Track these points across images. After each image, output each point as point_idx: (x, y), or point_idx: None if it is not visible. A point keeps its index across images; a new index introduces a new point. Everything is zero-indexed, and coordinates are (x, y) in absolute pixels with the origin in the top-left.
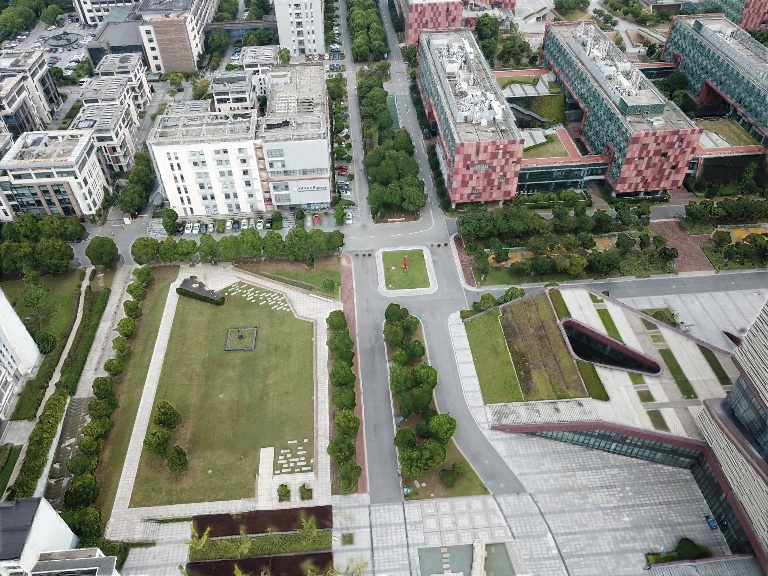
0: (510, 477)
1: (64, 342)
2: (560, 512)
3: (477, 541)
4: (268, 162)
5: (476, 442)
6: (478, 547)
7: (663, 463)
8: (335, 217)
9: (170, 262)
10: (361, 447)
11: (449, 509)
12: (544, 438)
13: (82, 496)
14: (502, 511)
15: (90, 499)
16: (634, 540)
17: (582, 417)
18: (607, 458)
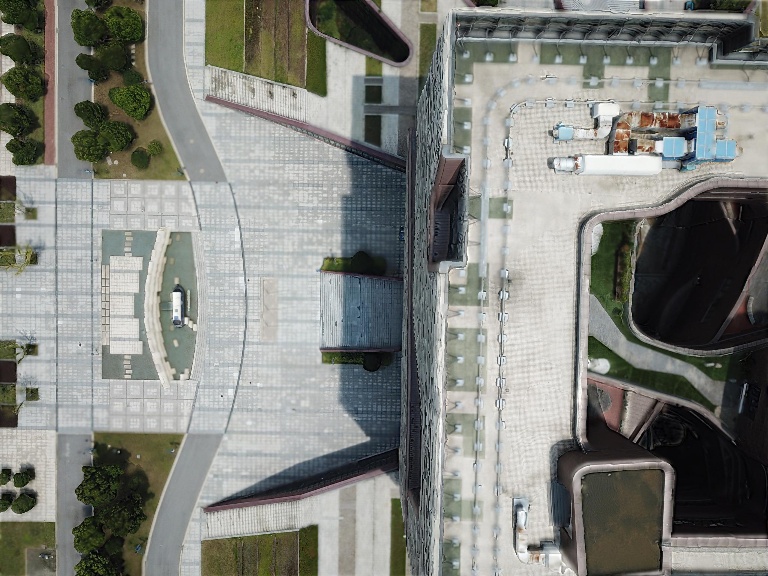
0: (213, 163)
1: None
2: (255, 207)
3: (161, 229)
4: None
5: (185, 115)
6: (160, 236)
7: (384, 164)
8: None
9: None
10: (51, 108)
11: (140, 192)
12: (264, 119)
13: None
14: (195, 200)
15: None
16: (319, 243)
17: (291, 112)
18: (326, 151)
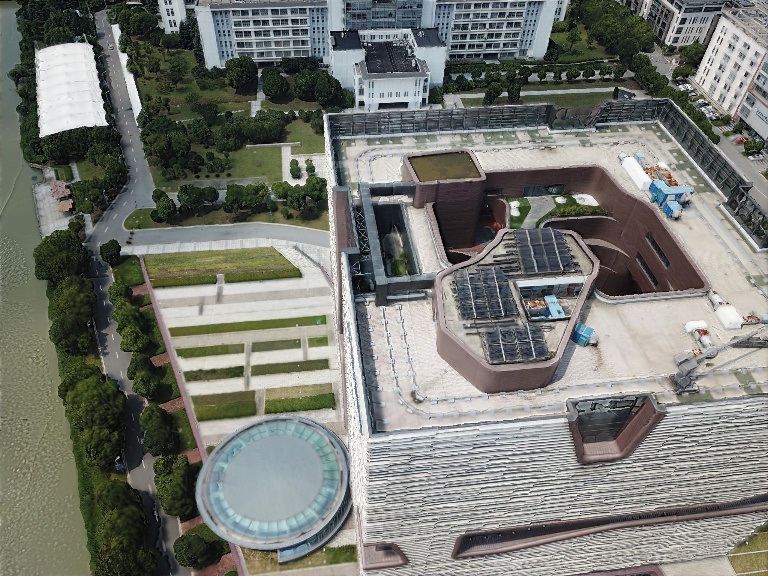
0: None
1: (555, 63)
2: None
3: None
4: (759, 73)
5: None
6: None
7: None
8: (744, 143)
9: (642, 83)
10: None
11: None
12: None
13: (461, 81)
14: None
15: (461, 86)
16: None
17: None
18: None
